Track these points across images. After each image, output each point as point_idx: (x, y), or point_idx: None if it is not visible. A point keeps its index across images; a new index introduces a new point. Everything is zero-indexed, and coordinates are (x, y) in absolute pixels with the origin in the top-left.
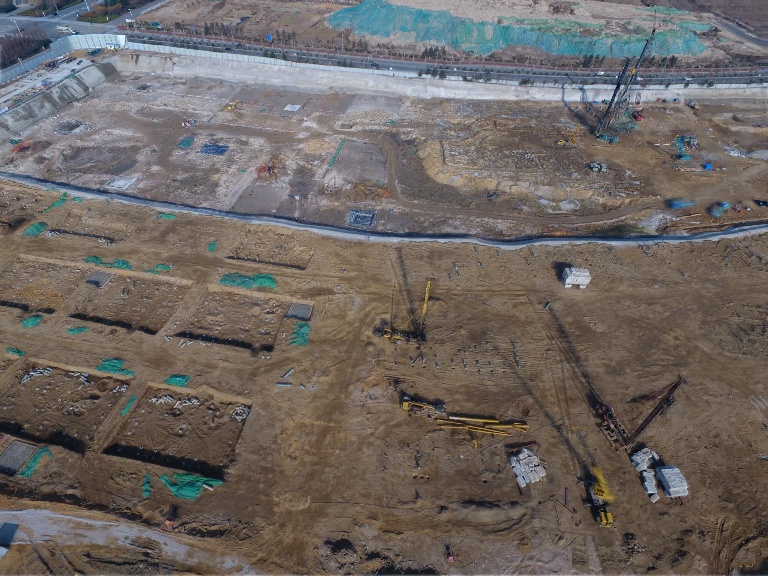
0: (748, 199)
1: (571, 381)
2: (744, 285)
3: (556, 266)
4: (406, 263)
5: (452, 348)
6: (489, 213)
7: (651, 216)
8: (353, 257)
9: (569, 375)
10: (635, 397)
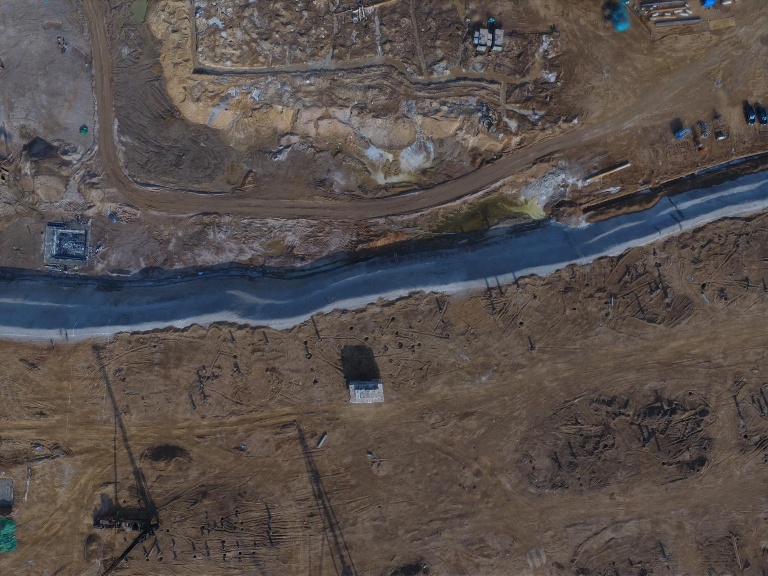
0: (737, 102)
1: (330, 557)
2: (613, 357)
3: (348, 357)
4: (129, 382)
5: (193, 527)
6: (274, 204)
7: (545, 177)
8: (49, 382)
9: (329, 549)
10: (397, 570)
